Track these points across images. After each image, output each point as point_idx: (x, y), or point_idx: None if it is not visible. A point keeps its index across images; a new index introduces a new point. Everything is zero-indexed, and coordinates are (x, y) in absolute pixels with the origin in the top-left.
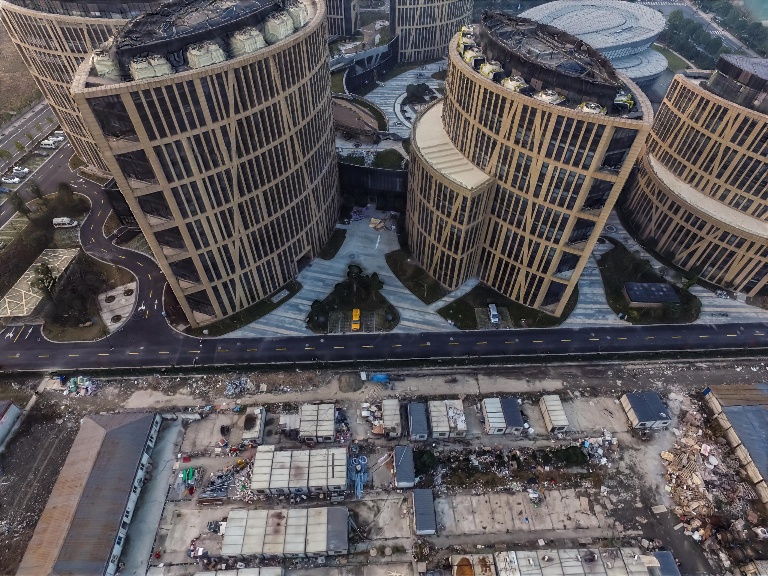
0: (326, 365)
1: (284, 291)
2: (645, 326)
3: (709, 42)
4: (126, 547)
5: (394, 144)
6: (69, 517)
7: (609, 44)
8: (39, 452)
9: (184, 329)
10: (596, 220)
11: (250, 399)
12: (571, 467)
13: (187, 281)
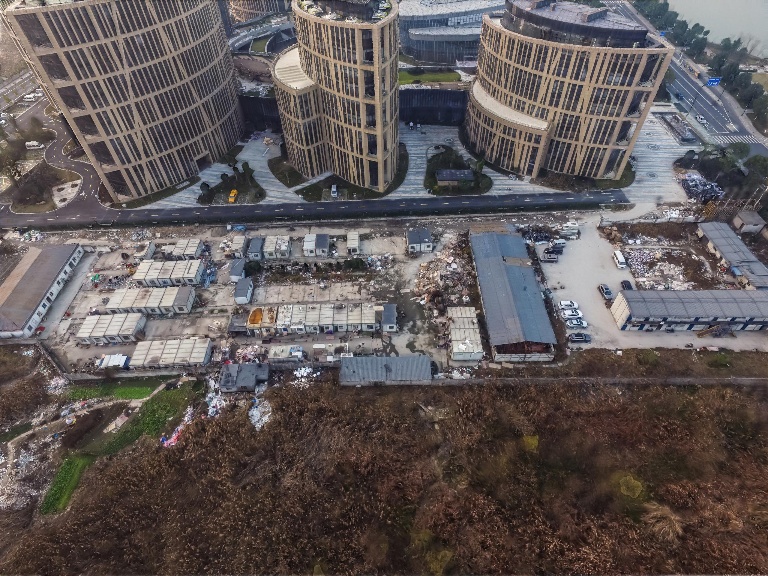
0: (203, 220)
1: (186, 182)
2: (445, 197)
3: None
4: (49, 311)
5: None
6: (12, 288)
7: (484, 6)
8: (0, 268)
9: (110, 205)
10: (374, 103)
11: None
12: (355, 272)
13: (107, 165)
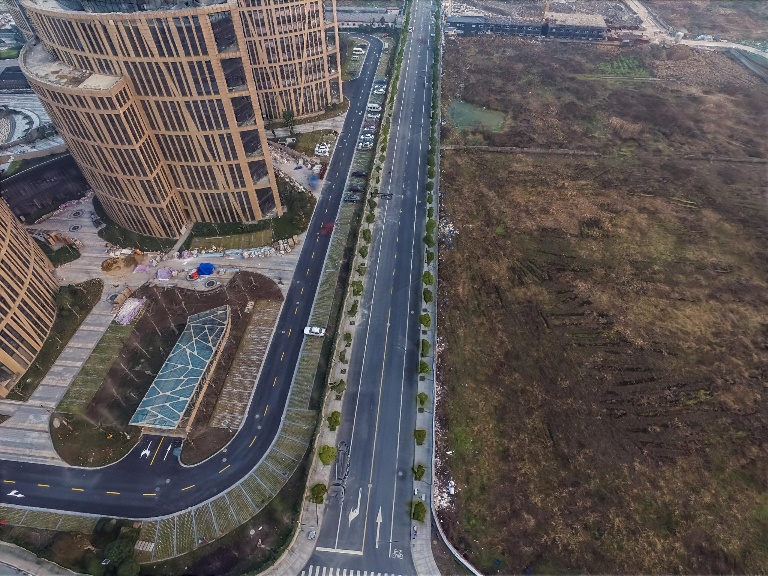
0: None
1: None
2: None
3: None
4: None
5: None
6: None
7: None
8: None
9: None
10: None
11: None
12: None
13: None
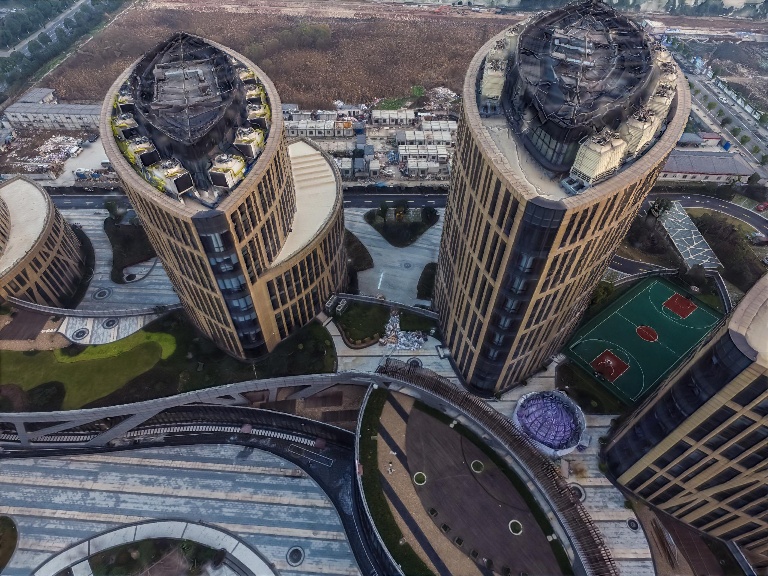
0: None
1: None
2: None
3: None
4: None
5: (351, 367)
6: None
7: None
8: None
9: None
10: None
11: None
12: None
13: None
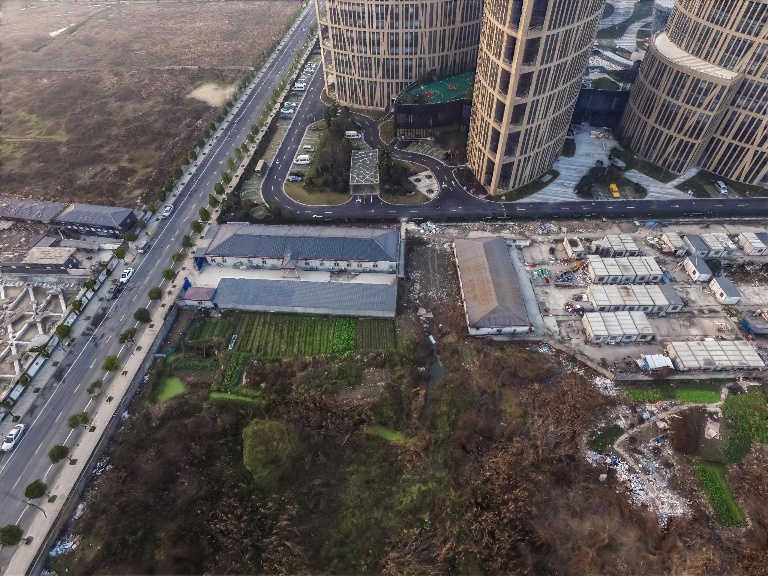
0: (608, 215)
1: (548, 175)
2: None
3: None
4: None
5: (601, 75)
6: (489, 282)
7: None
8: (428, 260)
9: (485, 197)
10: None
11: (557, 236)
12: None
13: None
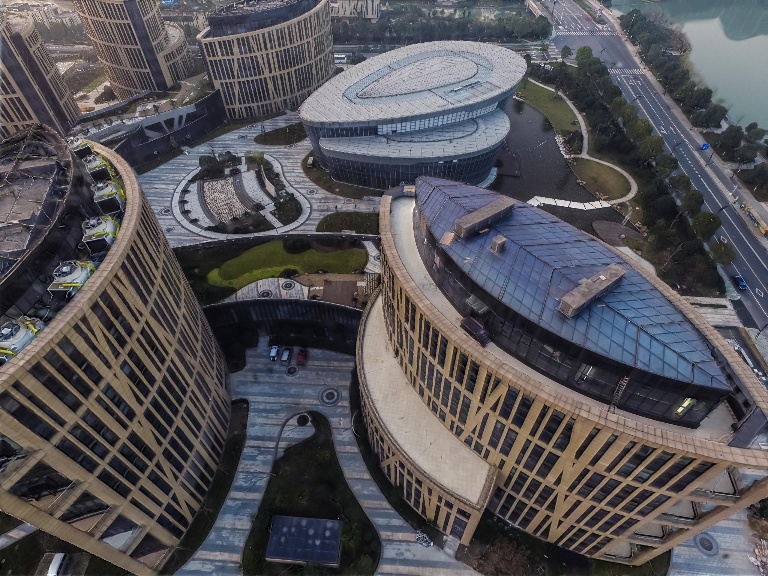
0: None
1: None
2: None
3: (605, 90)
4: None
5: None
6: None
7: (433, 109)
8: None
9: None
10: None
11: None
12: None
13: None
